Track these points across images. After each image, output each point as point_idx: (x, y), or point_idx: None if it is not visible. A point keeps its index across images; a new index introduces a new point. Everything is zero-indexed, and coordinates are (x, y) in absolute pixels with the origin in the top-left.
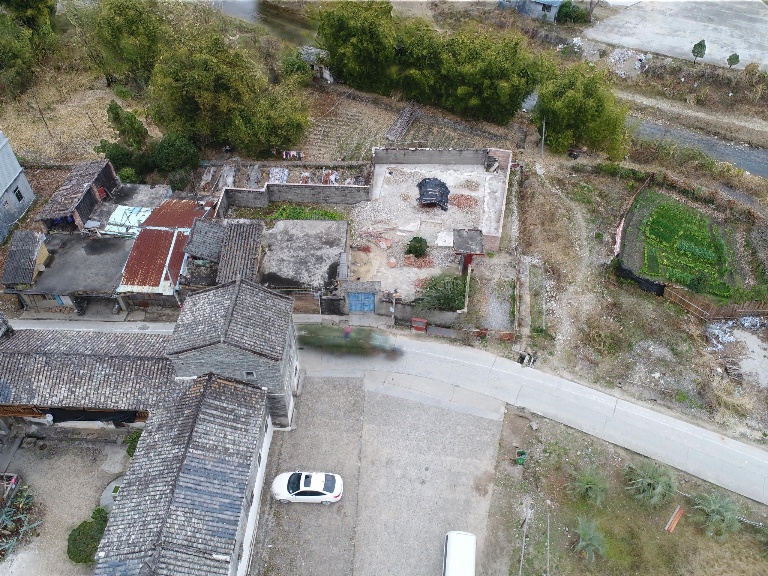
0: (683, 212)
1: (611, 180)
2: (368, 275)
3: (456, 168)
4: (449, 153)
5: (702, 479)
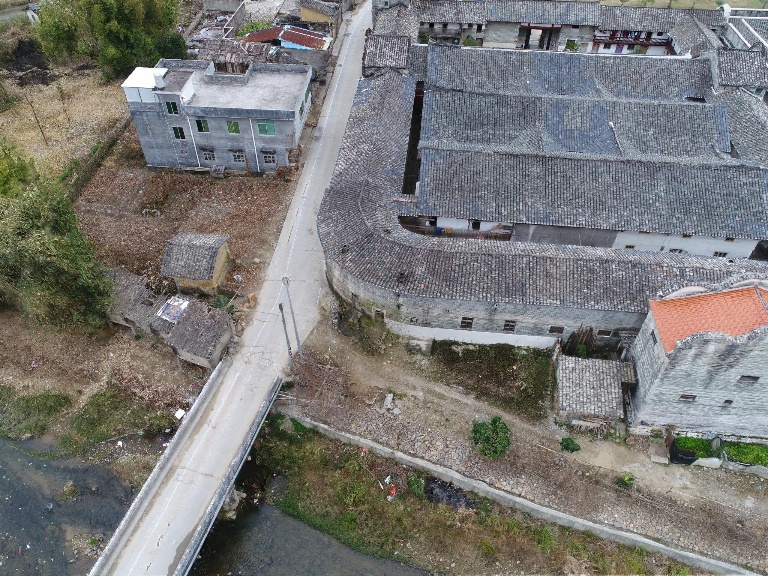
0: None
1: None
2: None
3: None
4: None
5: None
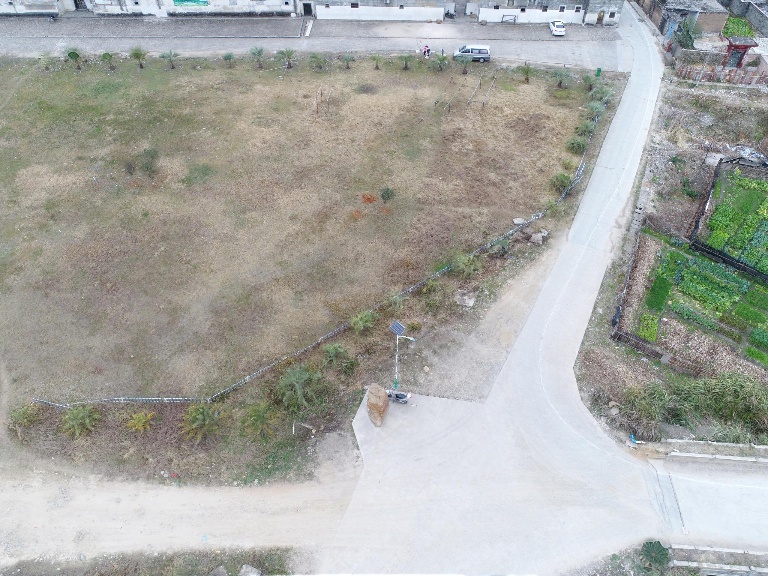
0: None
1: None
2: (701, 41)
3: None
4: None
5: None
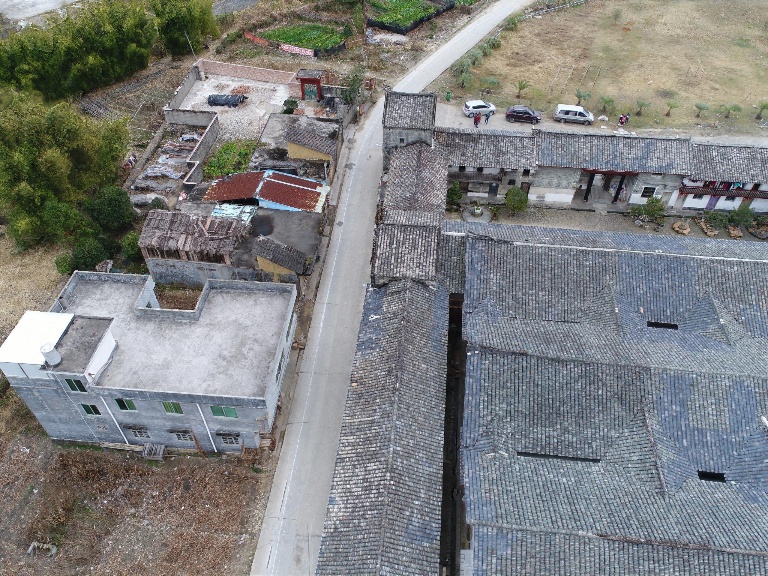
0: (278, 31)
1: (234, 45)
2: None
3: (195, 90)
4: (186, 83)
5: (457, 60)
